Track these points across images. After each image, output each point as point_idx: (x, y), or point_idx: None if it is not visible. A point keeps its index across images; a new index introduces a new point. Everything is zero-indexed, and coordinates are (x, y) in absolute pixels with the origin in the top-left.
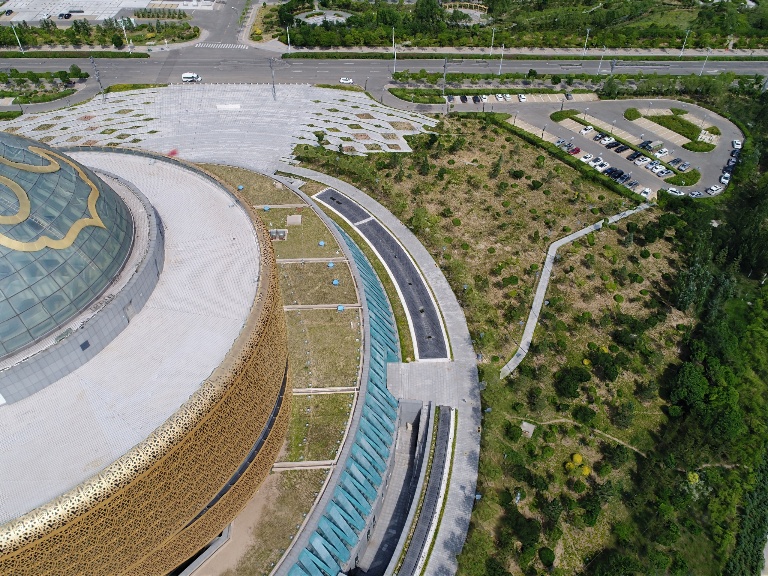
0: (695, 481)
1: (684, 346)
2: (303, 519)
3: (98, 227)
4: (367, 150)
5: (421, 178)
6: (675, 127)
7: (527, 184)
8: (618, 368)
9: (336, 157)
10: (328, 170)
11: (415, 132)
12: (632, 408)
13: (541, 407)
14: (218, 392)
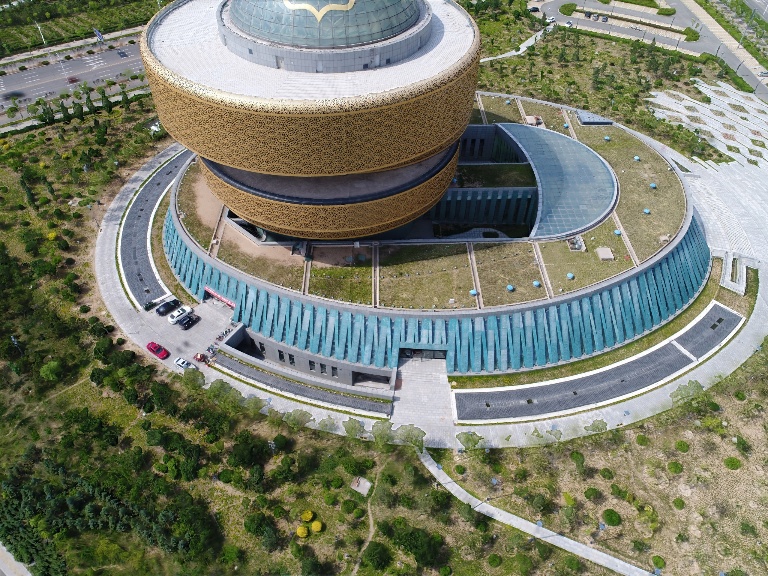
0: None
1: None
2: (264, 279)
3: (316, 18)
4: None
5: None
6: None
7: None
8: None
9: None
10: None
11: None
12: None
13: None
14: (208, 96)
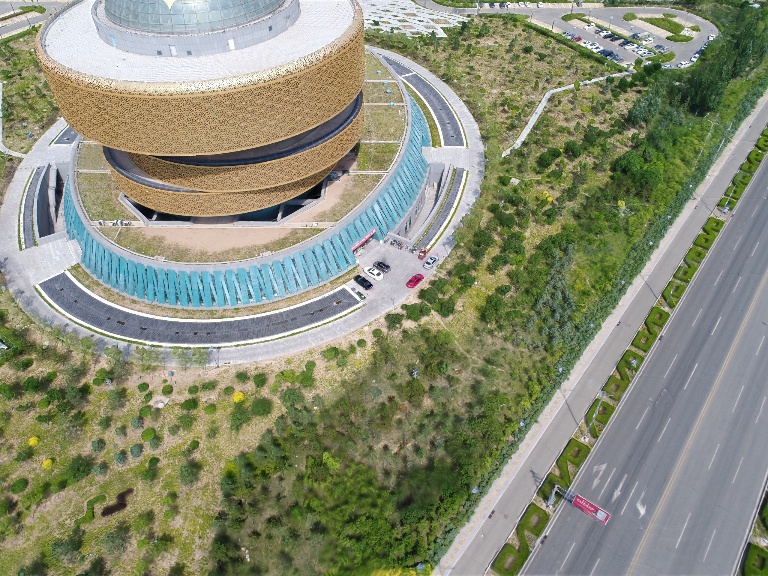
0: (622, 206)
1: (634, 148)
2: (368, 193)
3: None
4: (412, 35)
5: (453, 52)
6: (663, 25)
7: (535, 57)
8: (582, 151)
9: (389, 32)
10: (382, 46)
11: (450, 25)
12: (586, 167)
13: (525, 167)
14: (338, 47)
